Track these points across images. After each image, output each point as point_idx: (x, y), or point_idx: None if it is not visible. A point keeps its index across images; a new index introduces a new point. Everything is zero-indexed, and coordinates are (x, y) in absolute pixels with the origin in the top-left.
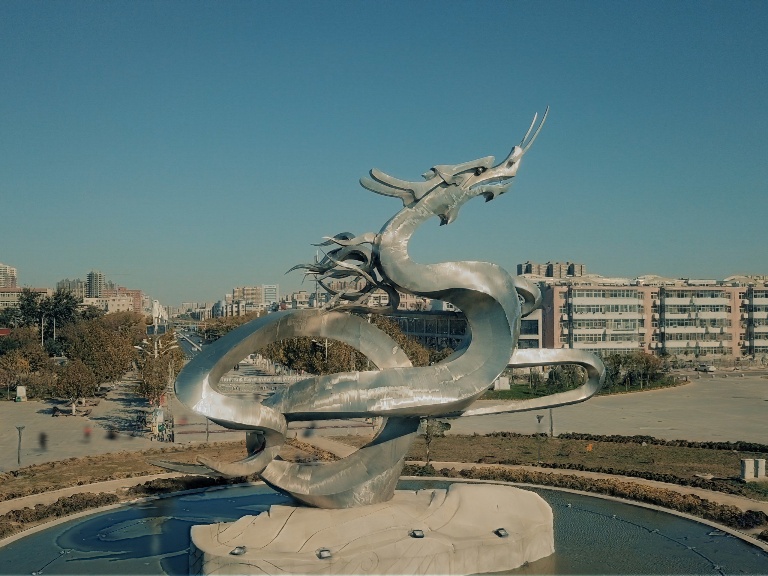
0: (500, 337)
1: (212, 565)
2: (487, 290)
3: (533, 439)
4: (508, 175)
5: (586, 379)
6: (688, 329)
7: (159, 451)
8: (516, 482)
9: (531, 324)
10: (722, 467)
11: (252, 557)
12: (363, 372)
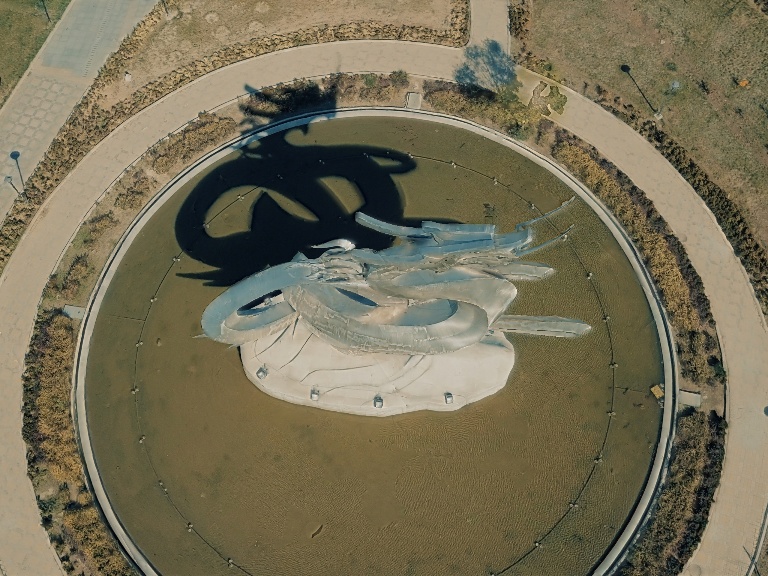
0: (479, 323)
1: (247, 372)
2: (473, 302)
3: None
4: (510, 257)
5: None
6: None
7: None
8: (587, 188)
9: None
10: None
11: (269, 385)
12: (353, 320)
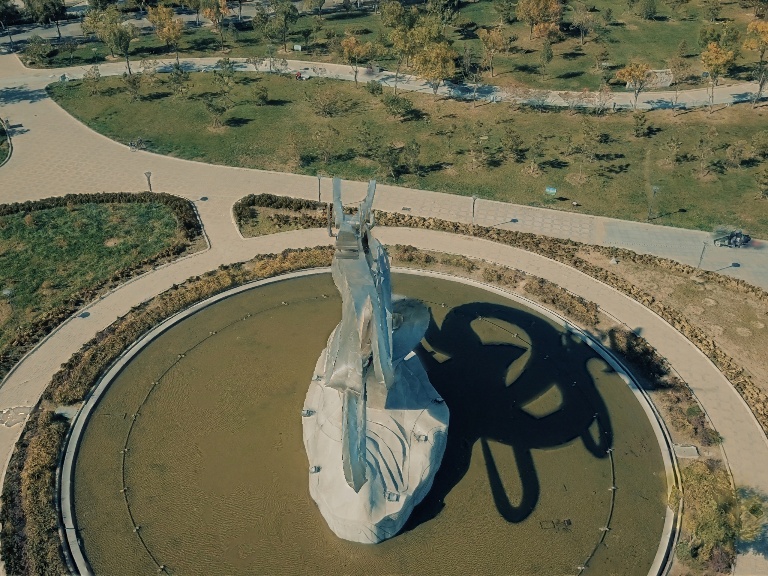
0: None
1: None
2: None
3: None
4: None
5: None
6: None
7: None
8: None
9: None
10: None
11: None
12: None
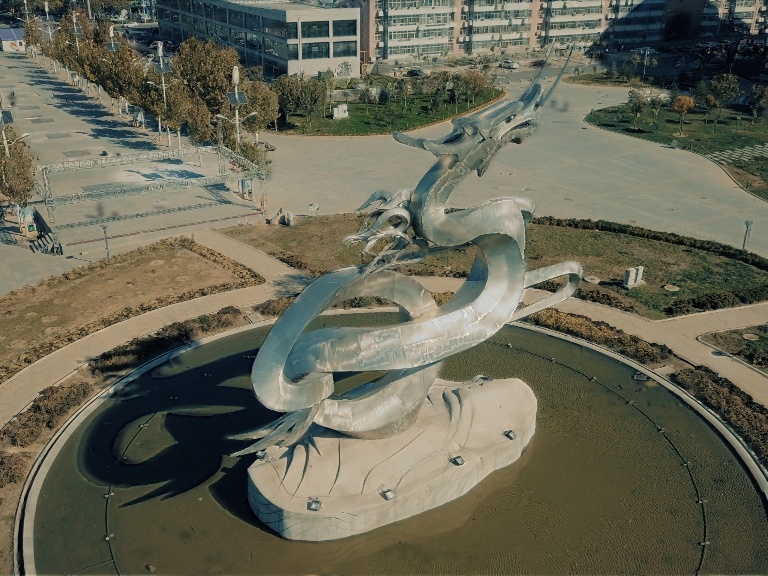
0: (514, 271)
1: (293, 520)
2: (507, 231)
3: None
4: None
5: (567, 282)
6: (494, 22)
7: (63, 279)
8: None
9: (349, 24)
10: (598, 261)
11: (331, 511)
12: (404, 328)
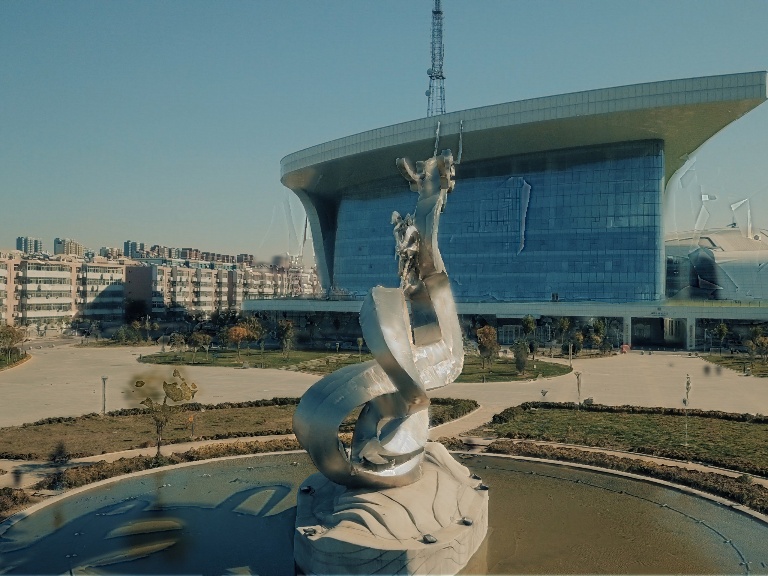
0: (451, 313)
1: (418, 560)
2: None
3: (93, 420)
4: None
5: None
6: None
7: None
8: (248, 454)
9: None
10: None
11: (446, 540)
12: (426, 349)
